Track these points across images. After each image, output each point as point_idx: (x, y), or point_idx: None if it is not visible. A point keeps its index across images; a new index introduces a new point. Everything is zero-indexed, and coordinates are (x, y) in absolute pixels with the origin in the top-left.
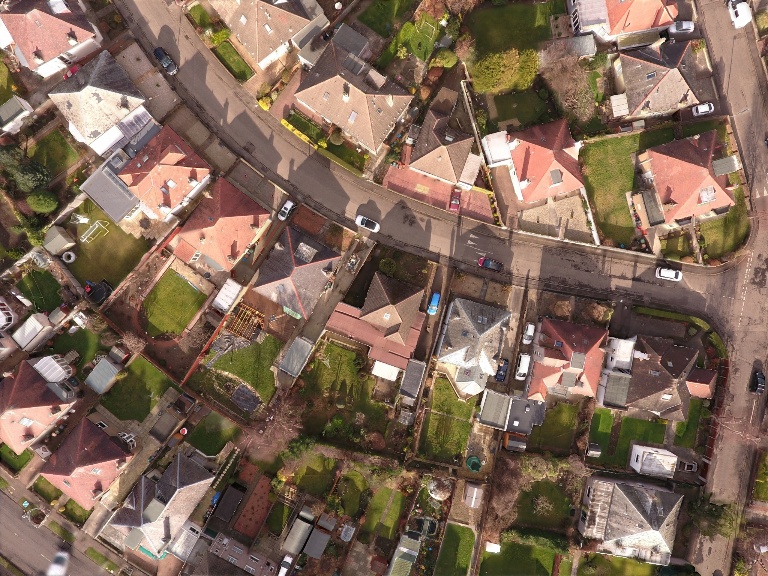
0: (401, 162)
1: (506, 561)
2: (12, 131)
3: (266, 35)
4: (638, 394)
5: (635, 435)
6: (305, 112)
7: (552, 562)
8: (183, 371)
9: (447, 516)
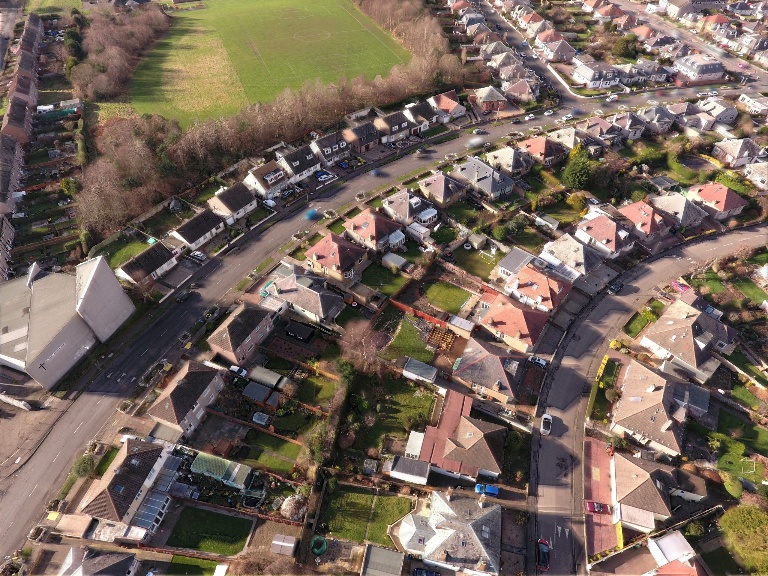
0: (614, 451)
1: None
2: (537, 222)
3: (668, 337)
4: None
5: None
6: (621, 373)
7: None
8: None
9: (265, 514)
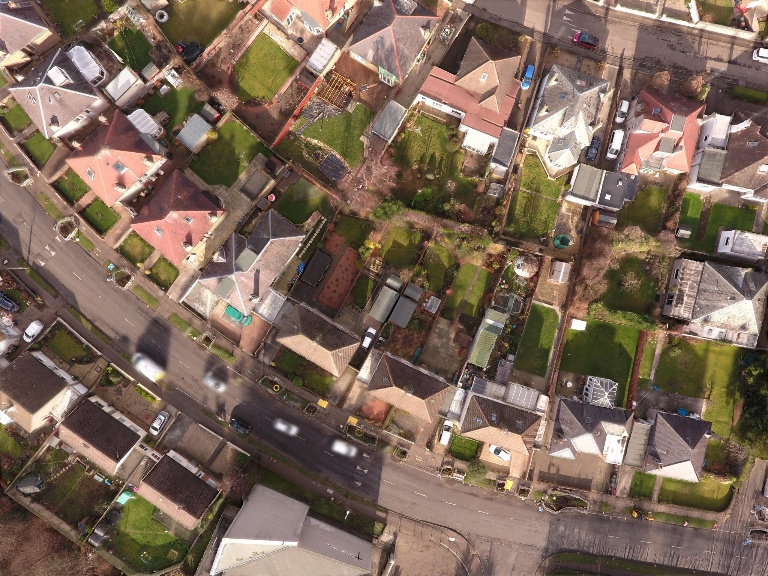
0: None
1: (589, 344)
2: None
3: None
4: (734, 168)
5: (724, 221)
6: None
7: (635, 347)
8: (273, 137)
9: (534, 291)
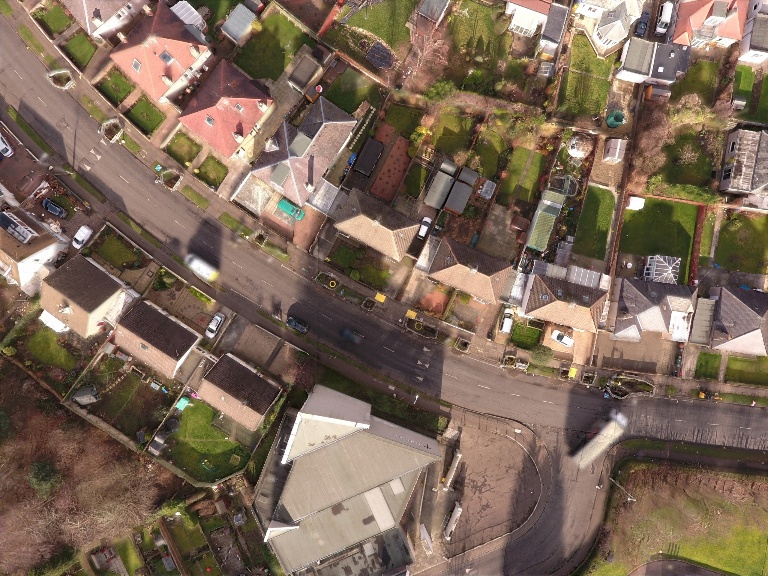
0: None
1: (647, 224)
2: None
3: None
4: None
5: None
6: None
7: (694, 224)
8: (317, 27)
9: (590, 170)
